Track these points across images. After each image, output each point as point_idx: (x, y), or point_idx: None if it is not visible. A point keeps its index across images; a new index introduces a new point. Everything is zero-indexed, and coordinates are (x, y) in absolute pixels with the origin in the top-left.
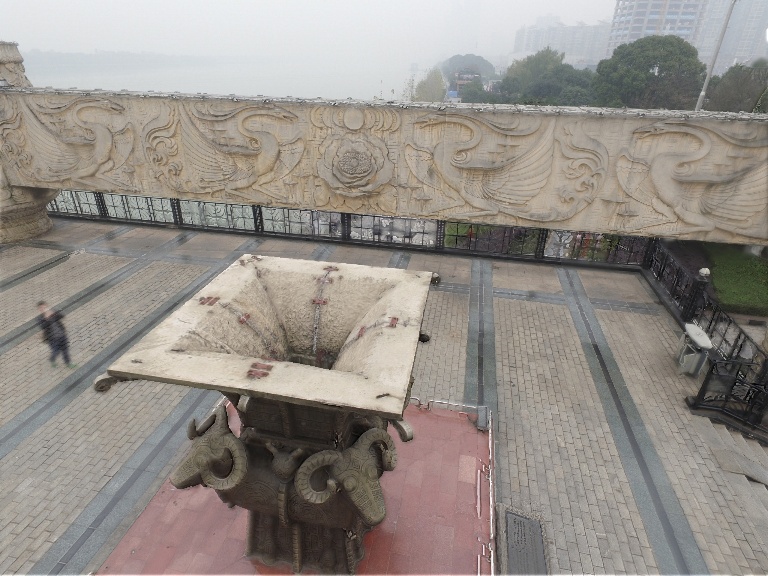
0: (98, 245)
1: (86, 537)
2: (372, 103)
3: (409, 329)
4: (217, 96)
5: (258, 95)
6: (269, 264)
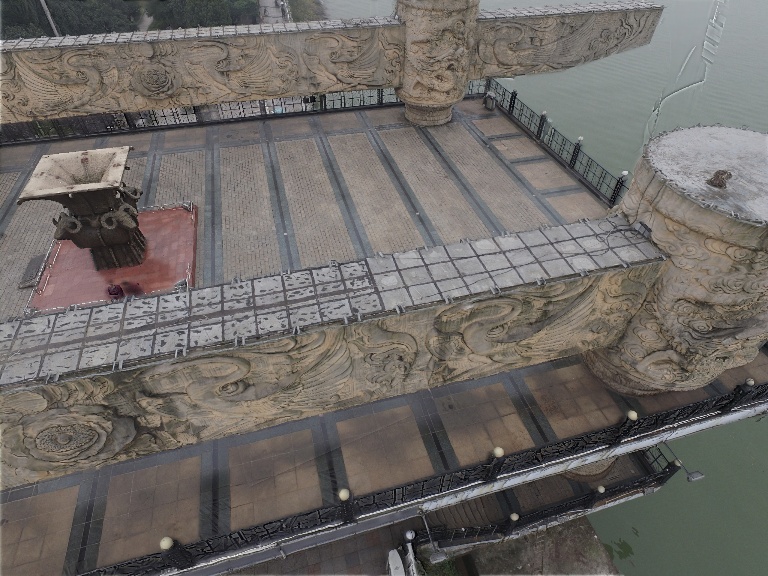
0: (503, 383)
1: (212, 231)
2: (8, 327)
3: (36, 173)
4: (294, 298)
5: (242, 338)
6: (103, 184)
